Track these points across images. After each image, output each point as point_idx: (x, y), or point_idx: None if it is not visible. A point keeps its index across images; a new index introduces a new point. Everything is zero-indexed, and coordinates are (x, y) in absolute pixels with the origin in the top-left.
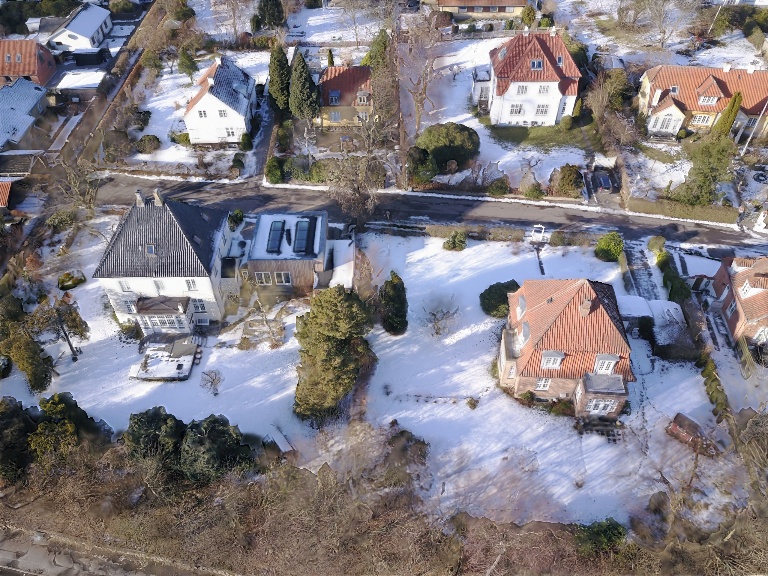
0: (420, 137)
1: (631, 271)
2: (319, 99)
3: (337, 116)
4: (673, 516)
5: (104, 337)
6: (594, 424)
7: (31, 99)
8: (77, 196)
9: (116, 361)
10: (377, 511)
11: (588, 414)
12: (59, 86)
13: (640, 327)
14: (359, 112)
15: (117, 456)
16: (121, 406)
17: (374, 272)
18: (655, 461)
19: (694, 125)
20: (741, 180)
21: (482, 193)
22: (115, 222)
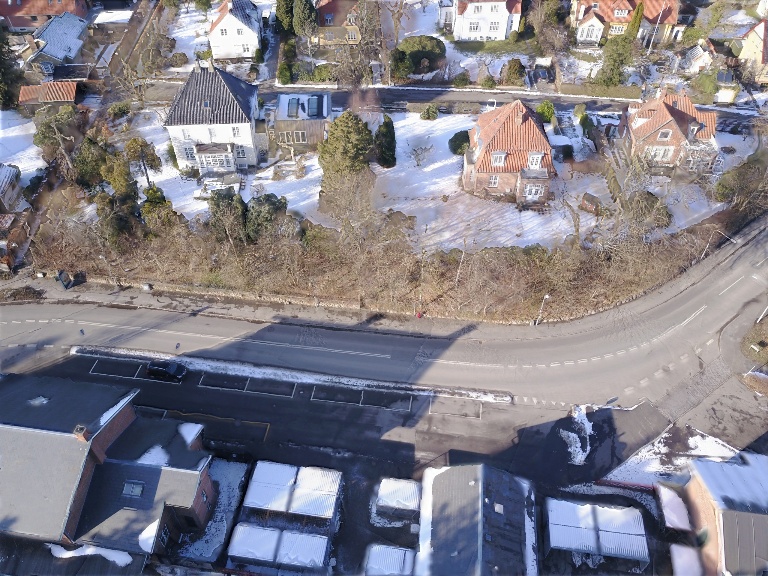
0: (399, 45)
1: (560, 128)
2: (317, 19)
3: (331, 35)
4: None
5: (169, 177)
6: (529, 206)
7: (78, 28)
8: (132, 90)
9: (181, 190)
10: None
11: (525, 200)
12: (96, 21)
13: (564, 154)
14: (349, 32)
15: (204, 215)
16: (191, 214)
17: (371, 117)
18: (570, 222)
19: (612, 34)
20: (646, 71)
21: (449, 85)
22: None
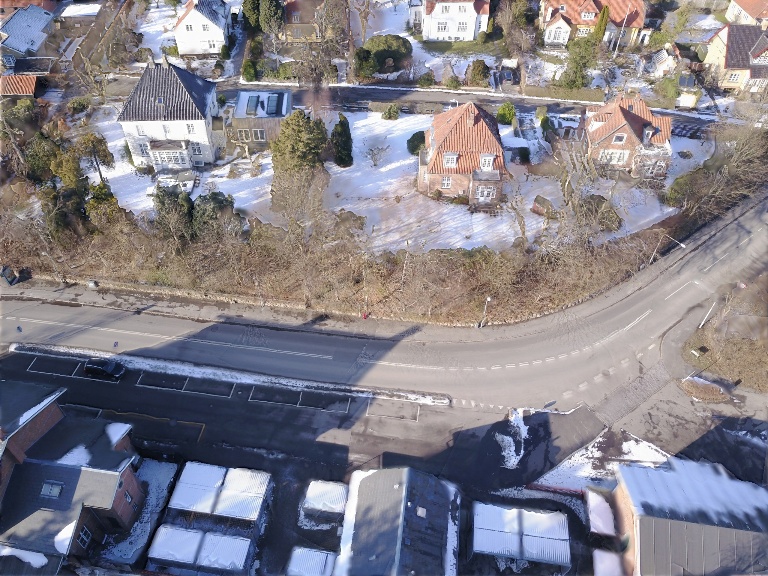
0: (365, 44)
1: (521, 130)
2: (284, 16)
3: (299, 33)
4: (526, 247)
5: (124, 173)
6: (481, 208)
7: (43, 20)
8: (92, 84)
9: (135, 187)
10: (330, 254)
11: (478, 201)
12: (63, 14)
13: (520, 156)
14: (316, 29)
15: (149, 213)
16: None
17: (327, 116)
18: None
19: (579, 37)
20: (612, 75)
21: (413, 85)
22: None
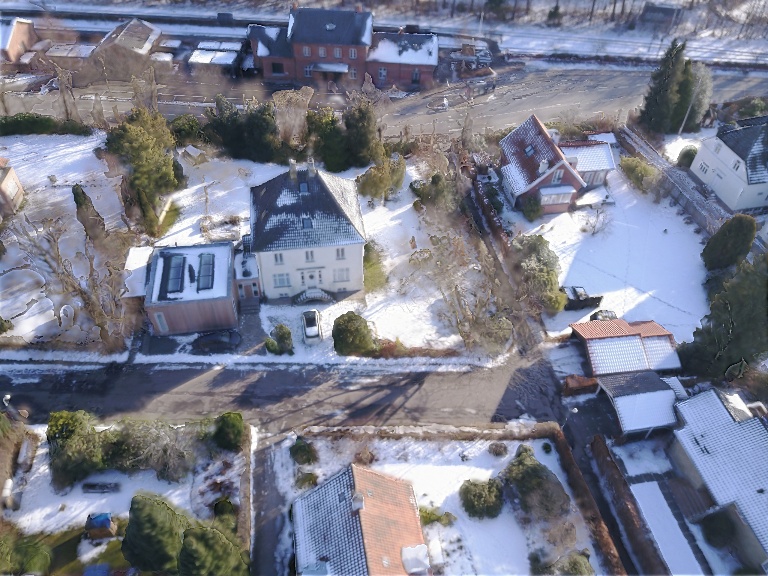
0: None
1: None
2: None
3: None
4: None
5: None
6: None
7: None
8: None
9: None
10: None
11: None
12: None
13: None
14: None
15: None
16: None
17: (97, 199)
18: None
19: None
20: None
21: None
22: (432, 338)
